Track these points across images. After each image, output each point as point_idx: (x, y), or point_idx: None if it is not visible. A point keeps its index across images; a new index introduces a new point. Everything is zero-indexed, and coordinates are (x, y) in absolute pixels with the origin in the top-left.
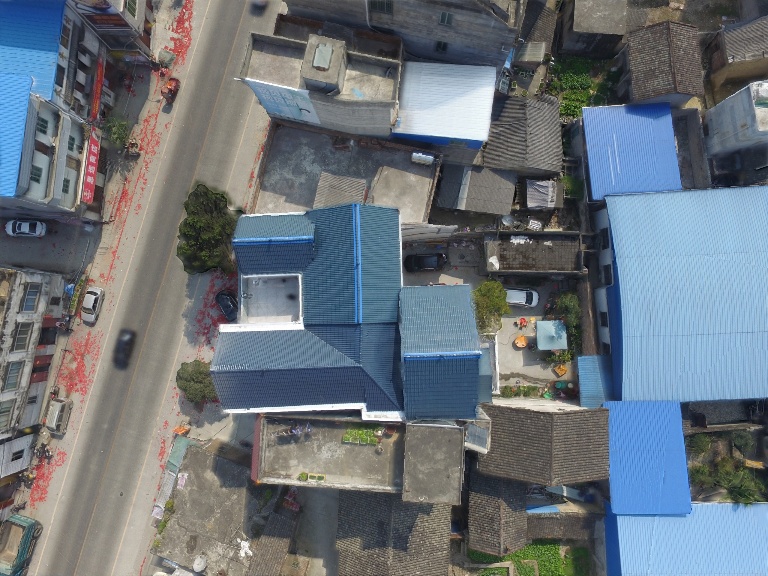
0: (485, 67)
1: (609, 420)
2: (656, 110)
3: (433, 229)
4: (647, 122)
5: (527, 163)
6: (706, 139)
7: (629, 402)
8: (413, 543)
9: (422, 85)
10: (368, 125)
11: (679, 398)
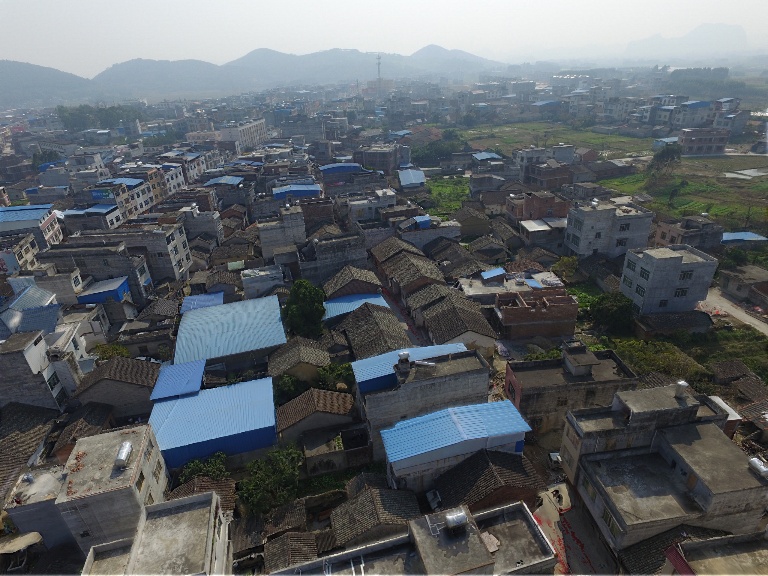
0: (125, 276)
1: (163, 371)
2: (217, 292)
3: (87, 325)
4: (212, 295)
5: (153, 312)
6: (244, 299)
7: (178, 364)
8: (2, 444)
9: (97, 285)
10: (65, 296)
11: (206, 358)
